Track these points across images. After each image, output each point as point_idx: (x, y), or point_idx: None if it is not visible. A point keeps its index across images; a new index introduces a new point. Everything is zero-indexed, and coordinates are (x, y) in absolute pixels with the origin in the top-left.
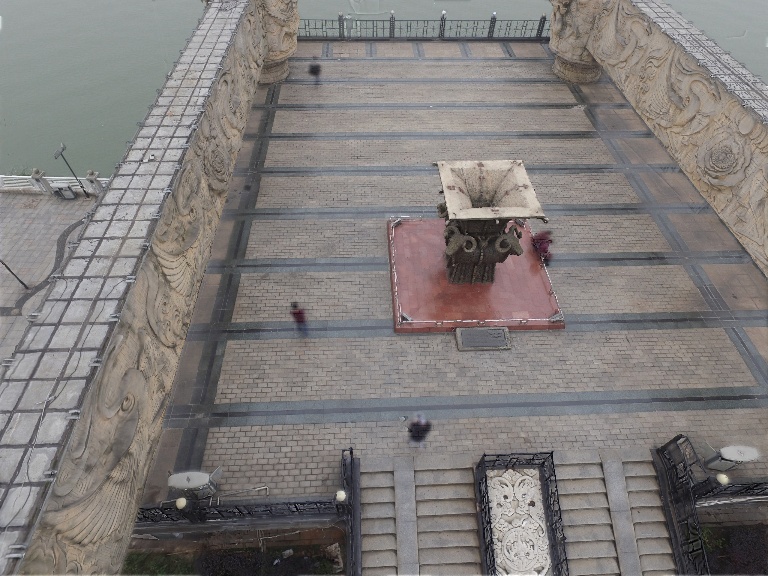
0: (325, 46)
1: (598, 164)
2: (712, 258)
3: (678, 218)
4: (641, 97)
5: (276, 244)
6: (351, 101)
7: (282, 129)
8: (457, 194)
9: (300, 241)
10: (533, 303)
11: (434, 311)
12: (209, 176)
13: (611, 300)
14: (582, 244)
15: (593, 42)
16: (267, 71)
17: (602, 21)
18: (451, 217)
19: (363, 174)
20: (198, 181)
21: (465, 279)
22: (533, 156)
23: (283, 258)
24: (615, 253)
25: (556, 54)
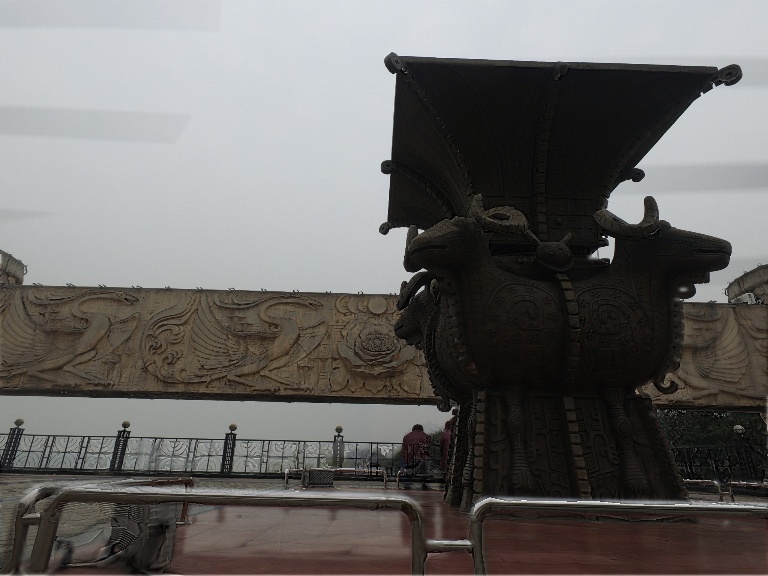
0: None
1: None
2: (414, 484)
3: None
4: (170, 370)
5: None
6: None
7: None
8: None
9: None
10: None
11: None
12: None
13: None
14: None
15: None
16: None
17: None
18: None
19: None
20: None
21: None
22: None
23: None
24: None
25: None
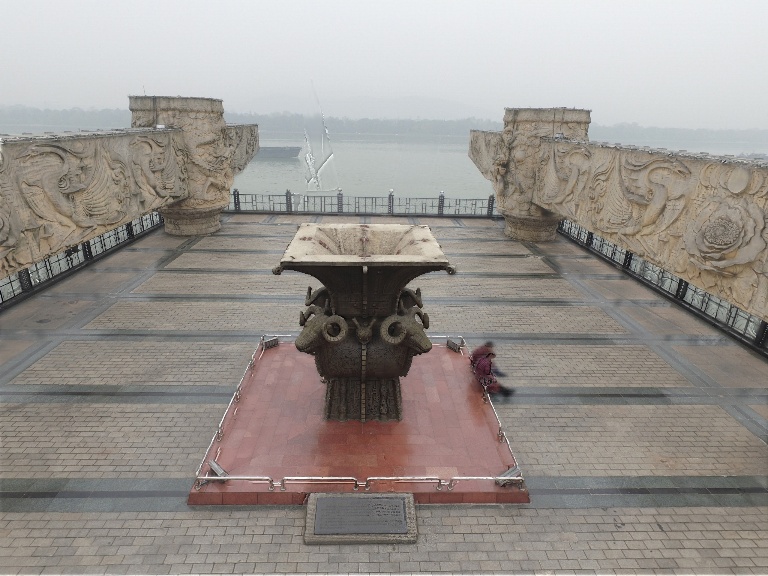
0: (270, 217)
1: (564, 298)
2: (762, 397)
3: (688, 350)
4: (597, 217)
5: (74, 367)
6: (275, 248)
7: (179, 265)
8: (311, 243)
9: (115, 364)
10: (467, 453)
11: (278, 463)
12: None
13: (611, 454)
14: (551, 376)
15: (537, 193)
16: (190, 222)
17: (542, 171)
18: (284, 259)
19: (254, 301)
20: None
21: (350, 412)
22: (480, 290)
23: (69, 384)
24: (604, 388)
25: (503, 213)
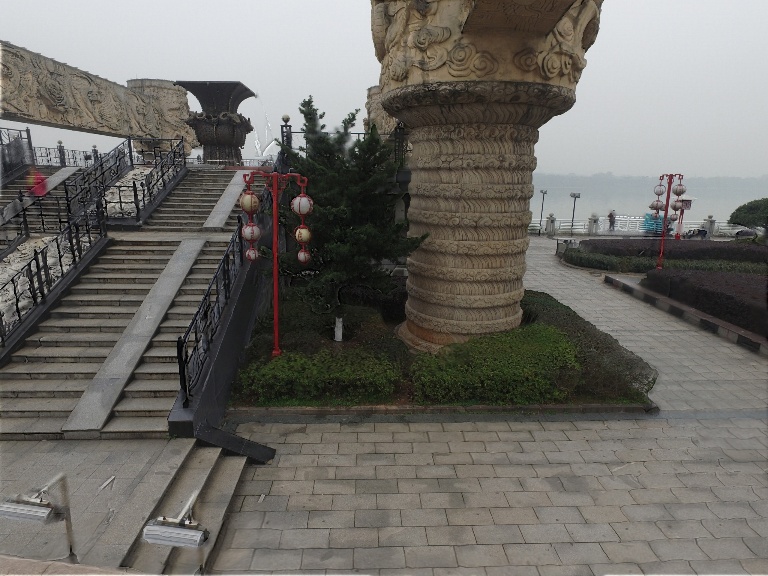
0: None
1: None
2: None
3: None
4: None
5: None
6: None
7: None
8: None
9: None
10: None
11: None
12: (41, 86)
13: None
14: None
15: None
16: None
17: None
18: None
19: None
20: (25, 71)
21: (213, 163)
22: None
23: None
24: None
25: None
